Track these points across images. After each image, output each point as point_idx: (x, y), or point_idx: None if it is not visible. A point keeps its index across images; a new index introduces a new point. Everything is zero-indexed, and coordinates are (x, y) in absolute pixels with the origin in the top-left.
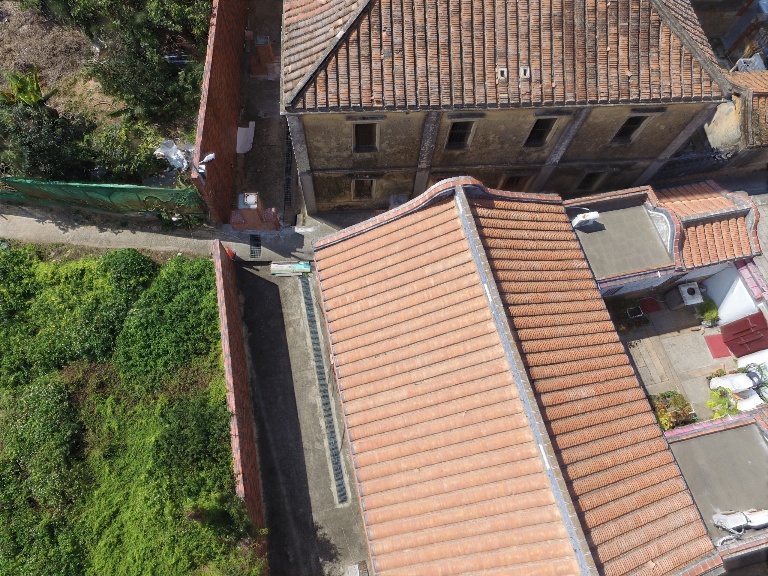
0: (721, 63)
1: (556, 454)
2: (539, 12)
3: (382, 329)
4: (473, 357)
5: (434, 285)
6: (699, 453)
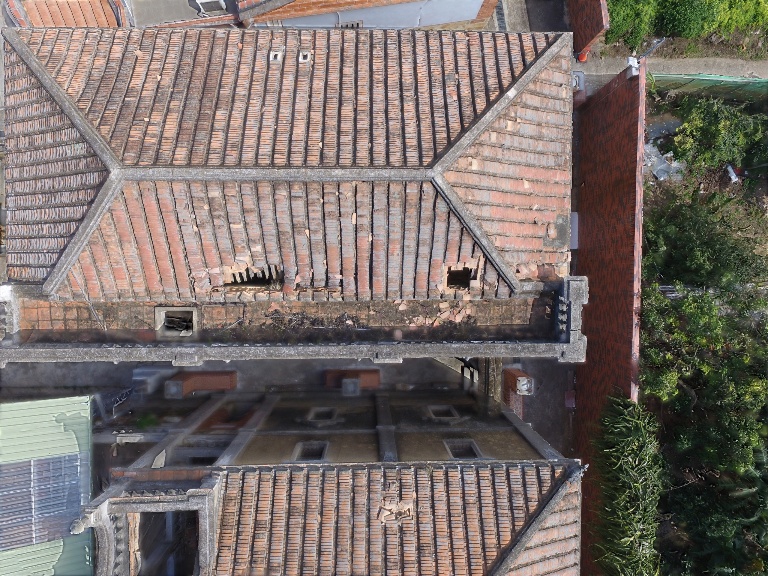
0: None
1: None
2: (248, 113)
3: None
4: None
5: None
6: None
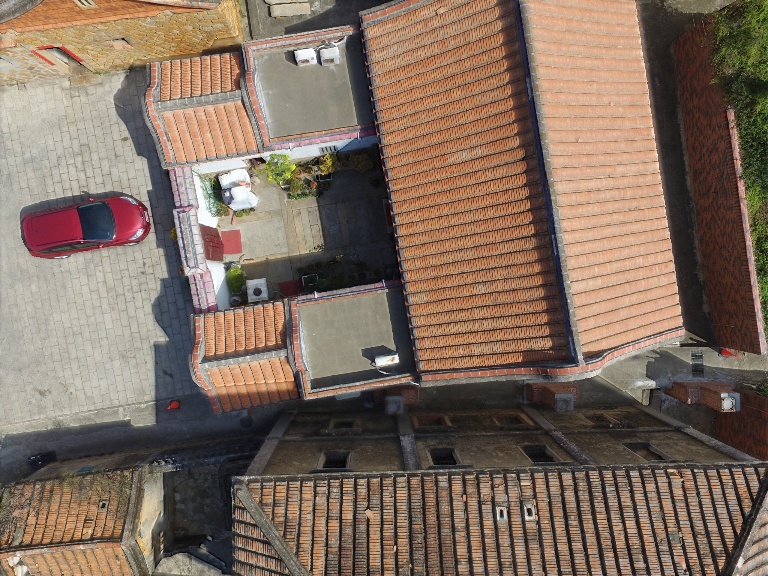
0: None
1: (518, 92)
2: None
3: (632, 233)
4: (571, 187)
5: (595, 266)
6: (333, 116)
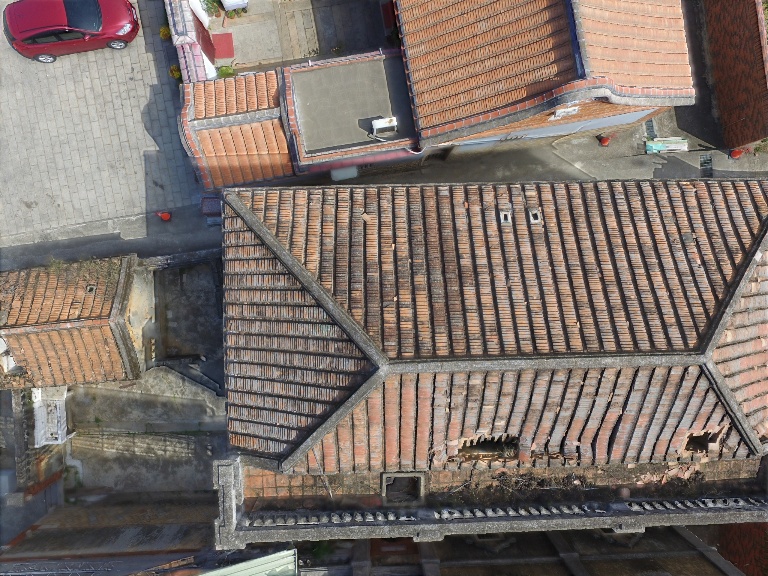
0: (77, 457)
1: None
2: (495, 288)
3: None
4: None
5: None
6: None
